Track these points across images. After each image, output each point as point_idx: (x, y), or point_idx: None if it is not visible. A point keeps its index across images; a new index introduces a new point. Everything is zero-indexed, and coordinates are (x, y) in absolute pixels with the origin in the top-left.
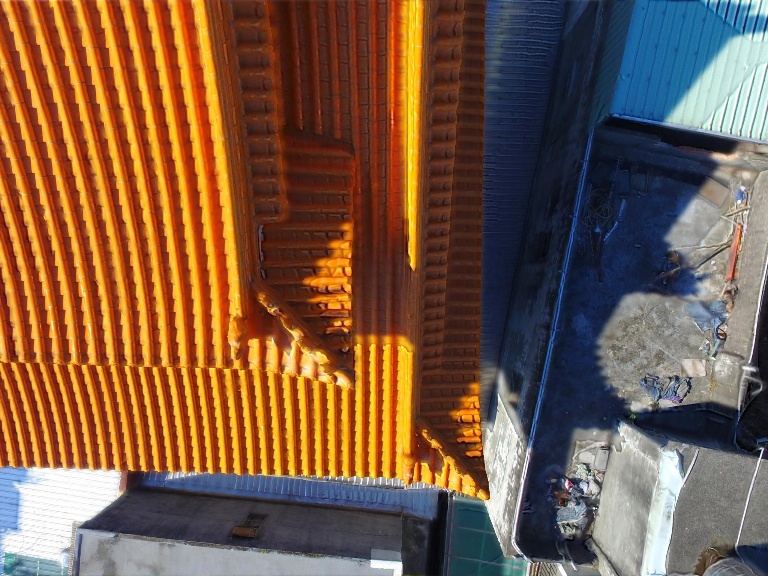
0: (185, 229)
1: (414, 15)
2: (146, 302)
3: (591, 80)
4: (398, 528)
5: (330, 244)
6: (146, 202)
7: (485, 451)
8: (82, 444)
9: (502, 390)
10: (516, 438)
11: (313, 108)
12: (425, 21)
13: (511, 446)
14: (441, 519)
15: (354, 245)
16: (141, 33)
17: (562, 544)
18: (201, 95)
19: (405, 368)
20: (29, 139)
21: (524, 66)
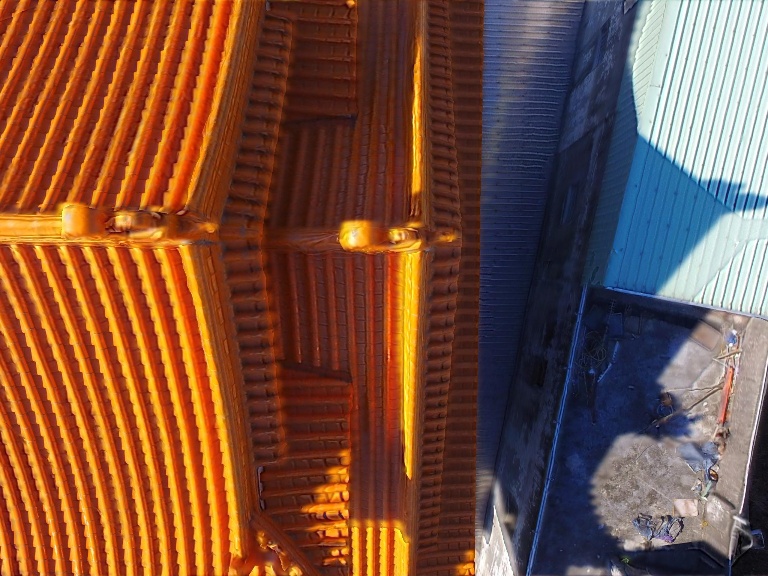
0: (186, 469)
1: (410, 289)
2: (148, 530)
3: (585, 226)
4: None
5: (328, 471)
6: (148, 449)
7: (481, 560)
8: None
9: (498, 505)
10: (511, 574)
11: (311, 346)
12: (420, 296)
13: None
14: None
15: (351, 449)
16: (144, 323)
17: None
18: (202, 369)
19: (401, 550)
20: (34, 400)
21: (520, 178)
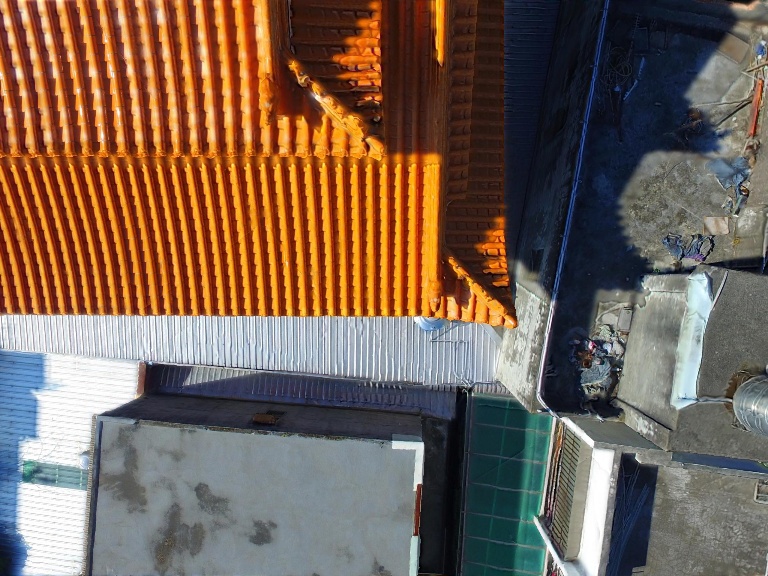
0: None
1: None
2: (175, 82)
3: None
4: (417, 422)
5: (359, 22)
6: None
7: (504, 342)
8: (106, 287)
9: (520, 276)
10: (538, 302)
11: None
12: None
13: (533, 313)
14: (460, 419)
15: None
16: None
17: (587, 404)
18: None
19: (431, 189)
20: None
21: None
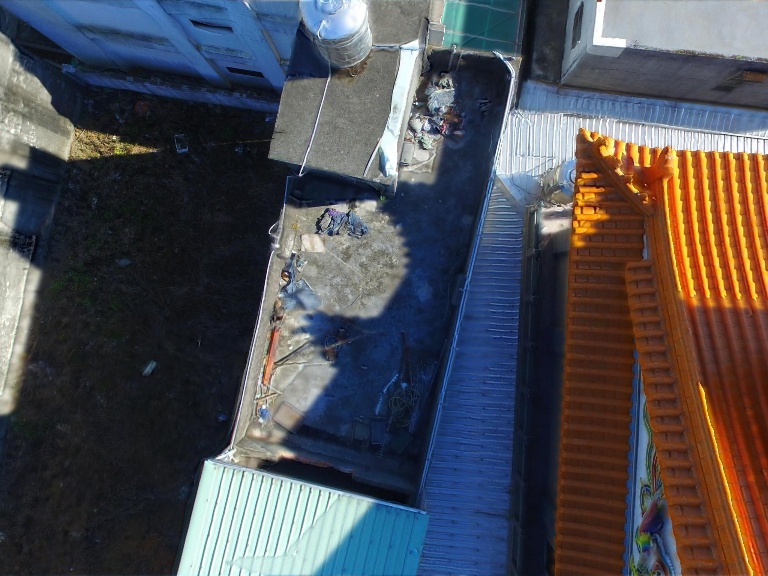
0: None
1: None
2: None
3: None
4: (574, 74)
5: None
6: None
7: None
8: None
9: None
10: None
11: None
12: None
13: None
14: (520, 81)
15: (756, 411)
16: None
17: (454, 68)
18: None
19: None
20: None
21: (428, 539)
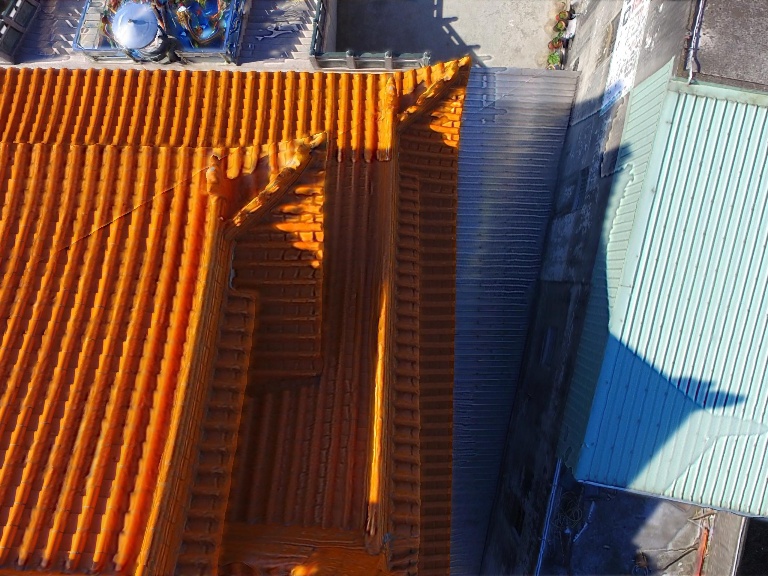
0: None
1: None
2: None
3: (561, 389)
4: None
5: None
6: None
7: None
8: None
9: None
10: None
11: None
12: None
13: None
14: None
15: None
16: None
17: None
18: None
19: None
20: None
21: (502, 304)
